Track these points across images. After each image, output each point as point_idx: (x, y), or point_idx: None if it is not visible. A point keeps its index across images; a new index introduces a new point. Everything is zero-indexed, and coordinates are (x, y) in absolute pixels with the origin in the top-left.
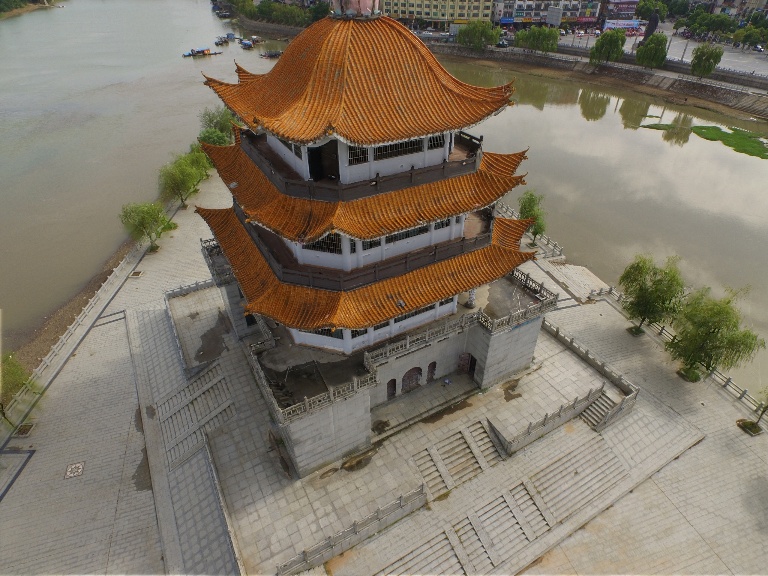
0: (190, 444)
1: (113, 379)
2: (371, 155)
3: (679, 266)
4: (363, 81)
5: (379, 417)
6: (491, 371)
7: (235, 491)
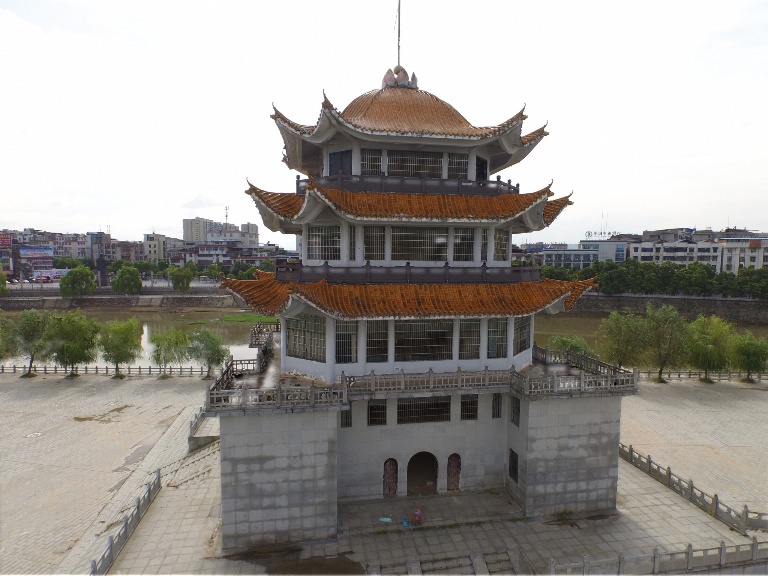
0: None
1: None
2: None
3: None
4: None
5: None
6: None
7: None
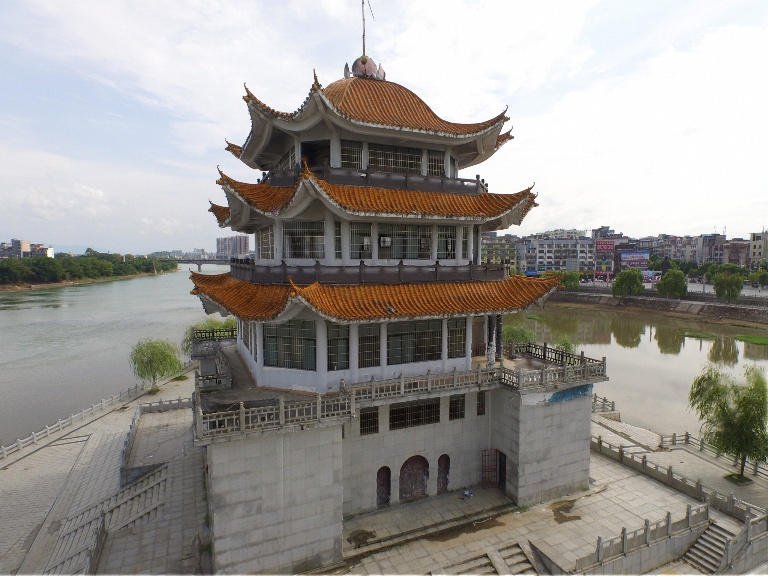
0: (81, 559)
1: (33, 492)
2: (365, 164)
3: (765, 375)
4: (361, 101)
5: (361, 526)
6: (529, 473)
7: None
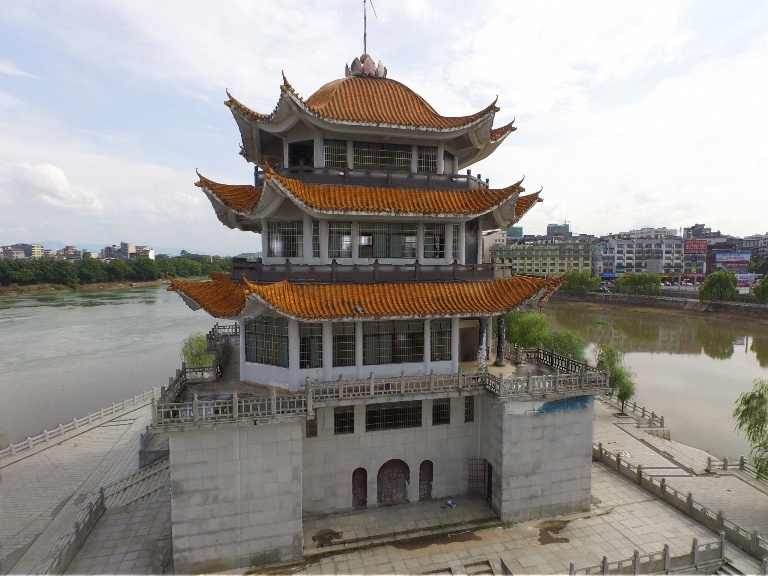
0: None
1: (74, 467)
2: (350, 162)
3: None
4: (349, 99)
5: (331, 526)
6: (515, 487)
7: (79, 575)
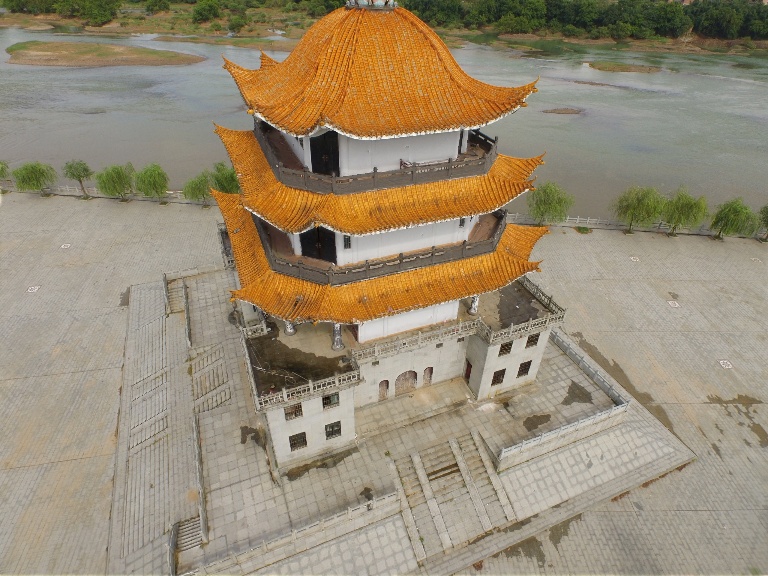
0: None
1: None
2: None
3: None
4: None
5: None
6: None
7: None
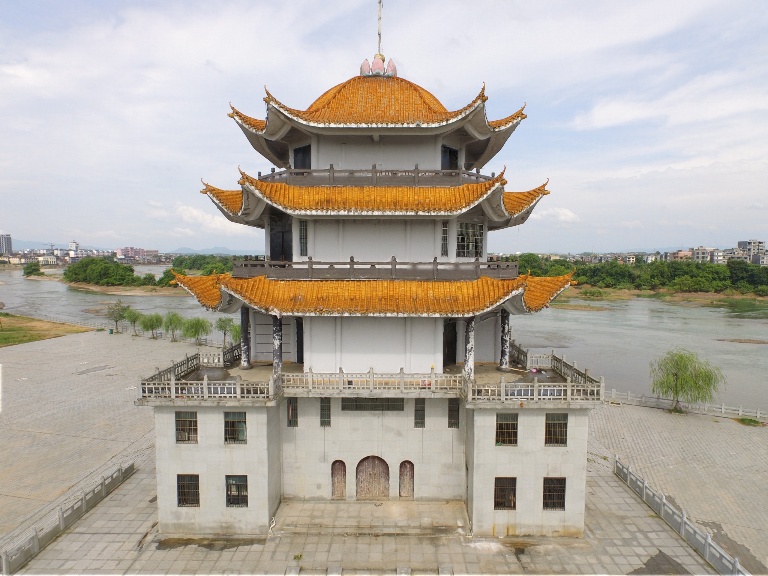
0: None
1: None
2: None
3: None
4: None
5: None
6: None
7: None
